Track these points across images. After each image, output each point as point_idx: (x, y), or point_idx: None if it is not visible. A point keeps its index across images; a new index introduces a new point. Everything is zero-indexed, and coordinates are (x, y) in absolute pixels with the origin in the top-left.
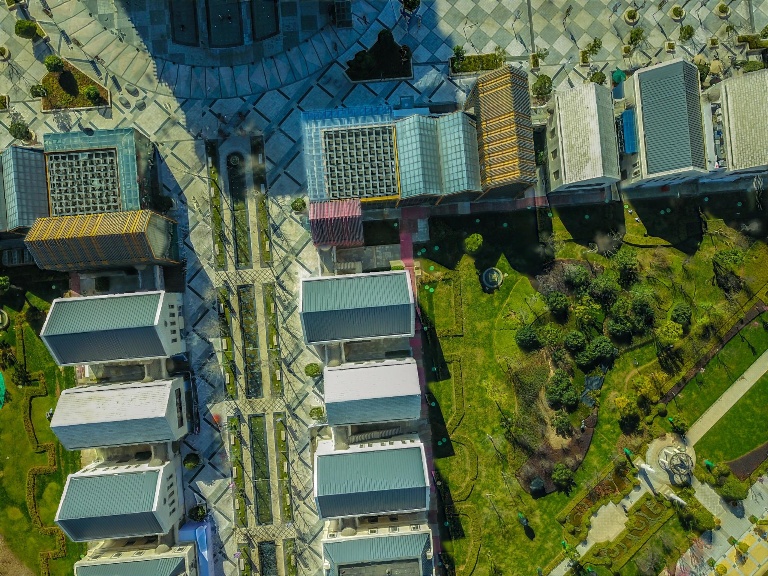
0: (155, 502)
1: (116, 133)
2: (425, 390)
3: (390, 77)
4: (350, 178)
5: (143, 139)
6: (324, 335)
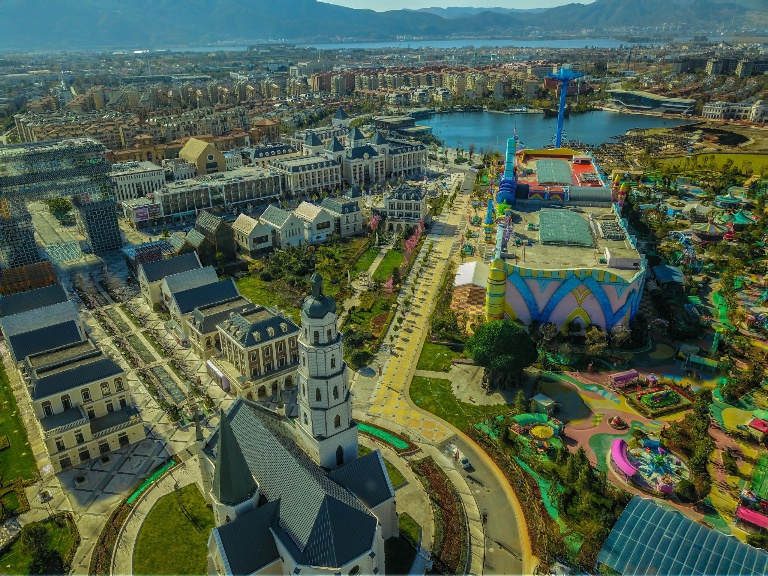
0: None
1: None
2: None
3: None
4: None
5: None
6: (157, 277)
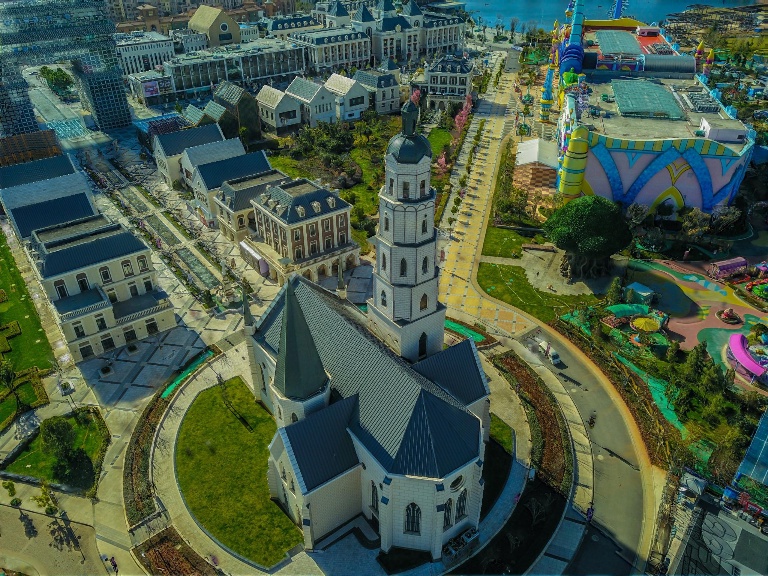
0: None
1: None
2: None
3: None
4: None
5: None
6: (175, 151)
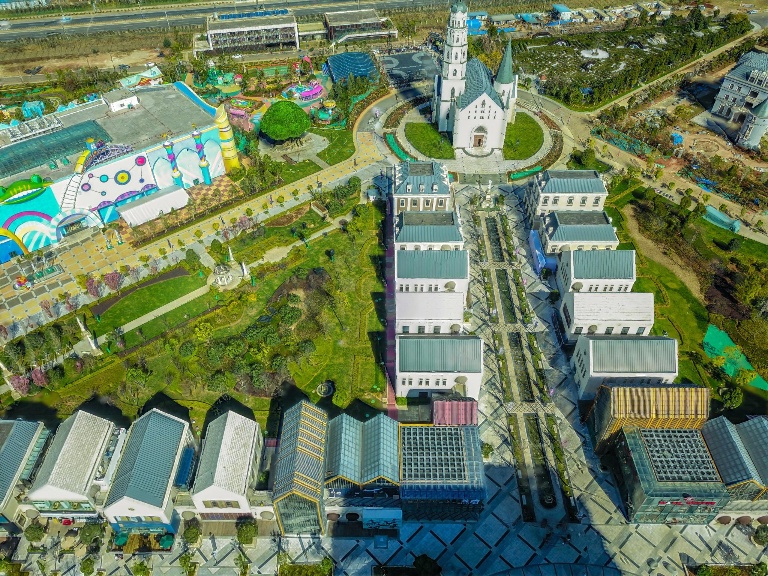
0: (572, 256)
1: (661, 494)
2: (387, 328)
3: (396, 568)
4: (442, 441)
5: None
6: None
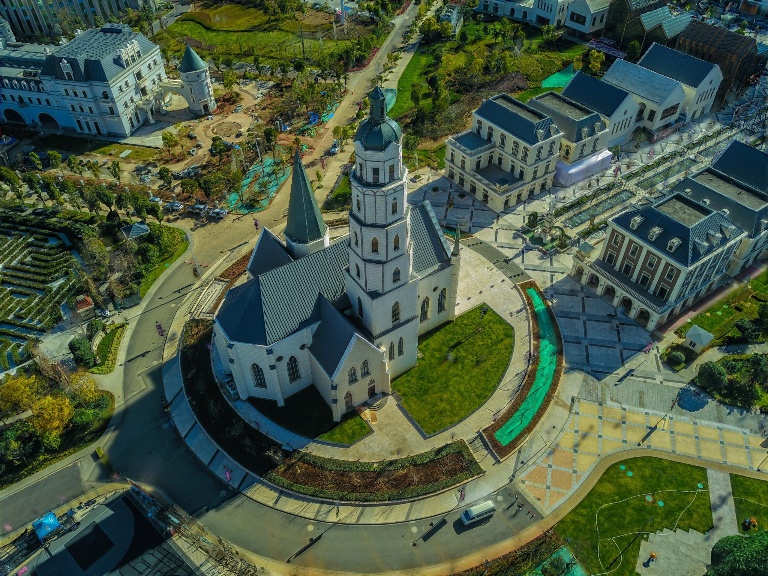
0: None
1: (762, 44)
2: None
3: None
4: None
5: (763, 66)
6: None
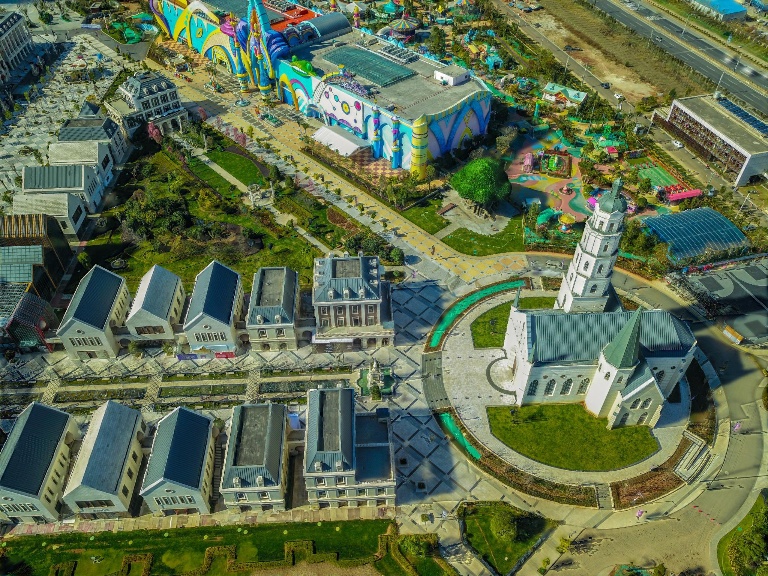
0: (175, 410)
1: None
2: None
3: None
4: (2, 306)
5: None
6: (100, 319)
